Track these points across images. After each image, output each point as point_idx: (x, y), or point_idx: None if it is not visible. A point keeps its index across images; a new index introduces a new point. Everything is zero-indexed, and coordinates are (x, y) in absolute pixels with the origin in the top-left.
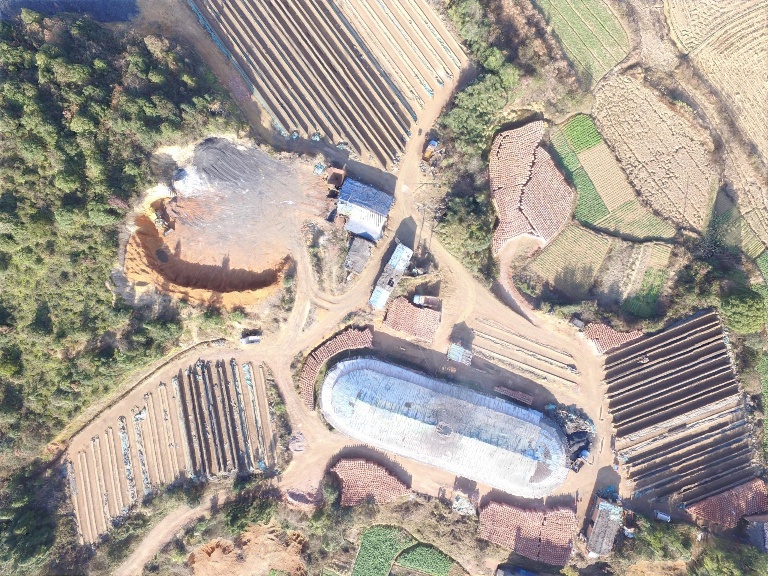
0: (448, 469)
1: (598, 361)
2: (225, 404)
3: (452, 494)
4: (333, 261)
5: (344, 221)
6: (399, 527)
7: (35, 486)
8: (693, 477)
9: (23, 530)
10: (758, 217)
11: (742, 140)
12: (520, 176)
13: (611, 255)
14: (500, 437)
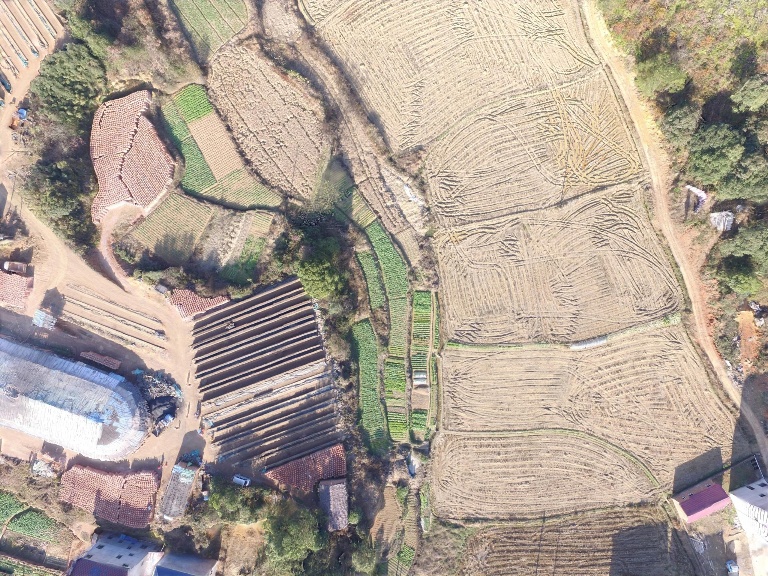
0: (26, 432)
1: (187, 327)
2: None
3: None
4: None
5: None
6: (12, 492)
7: None
8: (277, 442)
9: None
10: (372, 186)
11: (361, 110)
12: (121, 145)
13: (212, 223)
14: (67, 400)
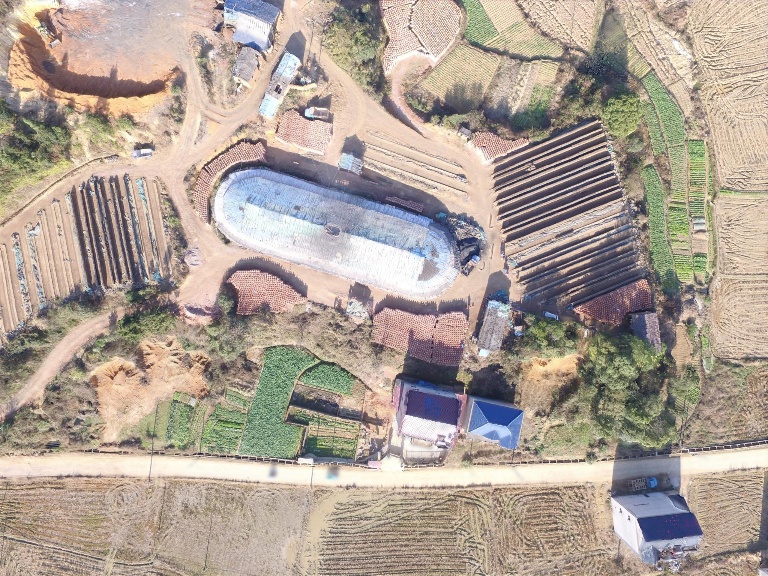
0: (340, 273)
1: (487, 170)
2: (118, 217)
3: None
4: (223, 75)
5: None
6: (301, 347)
7: None
8: (580, 280)
9: None
10: (644, 40)
11: None
12: None
13: (500, 72)
14: (388, 236)
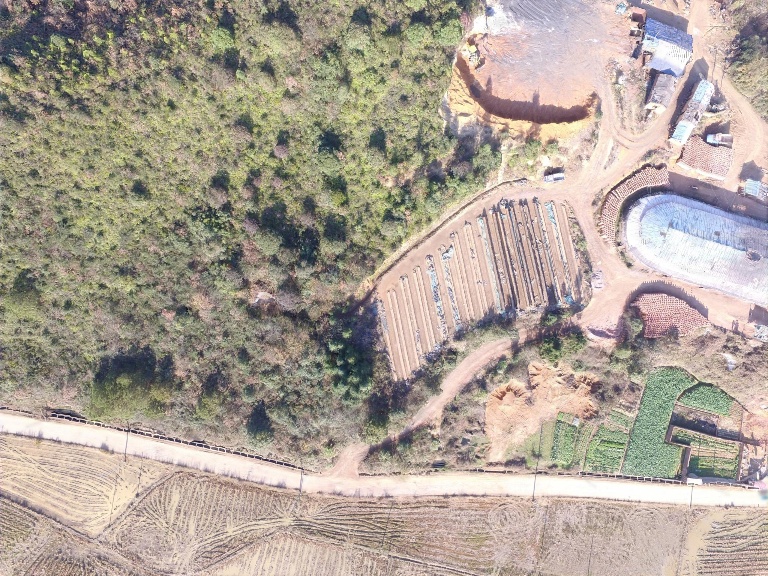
0: (750, 298)
1: None
2: (532, 240)
3: (745, 327)
4: (632, 100)
5: (642, 61)
6: (680, 368)
7: (351, 323)
8: None
9: (352, 360)
10: None
11: None
12: None
13: None
14: None
